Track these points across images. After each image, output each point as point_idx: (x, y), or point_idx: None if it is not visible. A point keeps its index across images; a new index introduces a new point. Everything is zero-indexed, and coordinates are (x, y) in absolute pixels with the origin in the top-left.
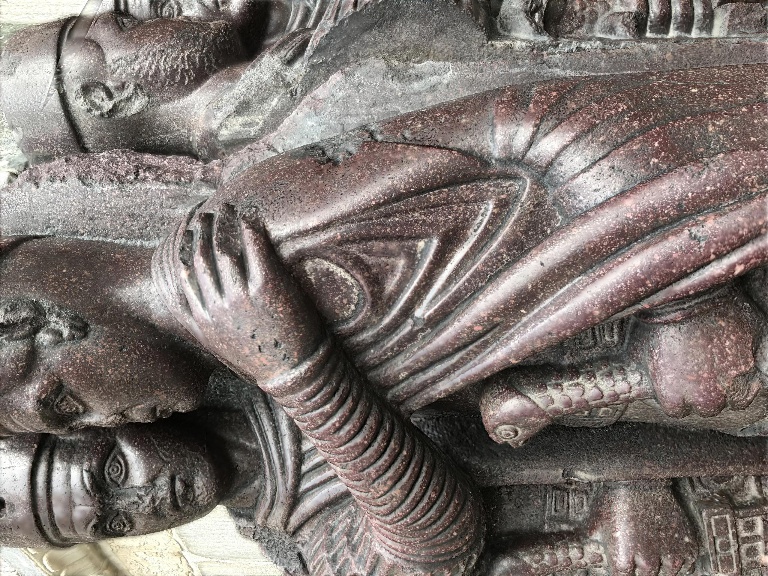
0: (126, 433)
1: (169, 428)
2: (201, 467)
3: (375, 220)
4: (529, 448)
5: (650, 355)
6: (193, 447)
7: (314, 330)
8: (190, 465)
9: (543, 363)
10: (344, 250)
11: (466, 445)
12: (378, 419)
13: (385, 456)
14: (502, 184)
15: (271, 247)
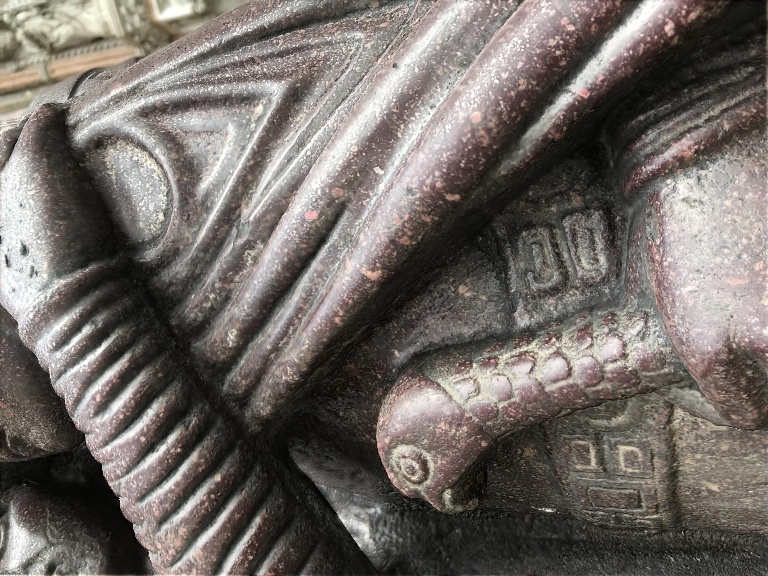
0: (22, 498)
1: (77, 502)
2: (91, 559)
3: (196, 79)
4: (541, 574)
5: (650, 257)
6: (93, 530)
7: (82, 234)
8: (78, 553)
9: (485, 336)
10: (150, 123)
11: (435, 558)
12: (174, 403)
13: (178, 475)
14: (386, 12)
15: (60, 126)
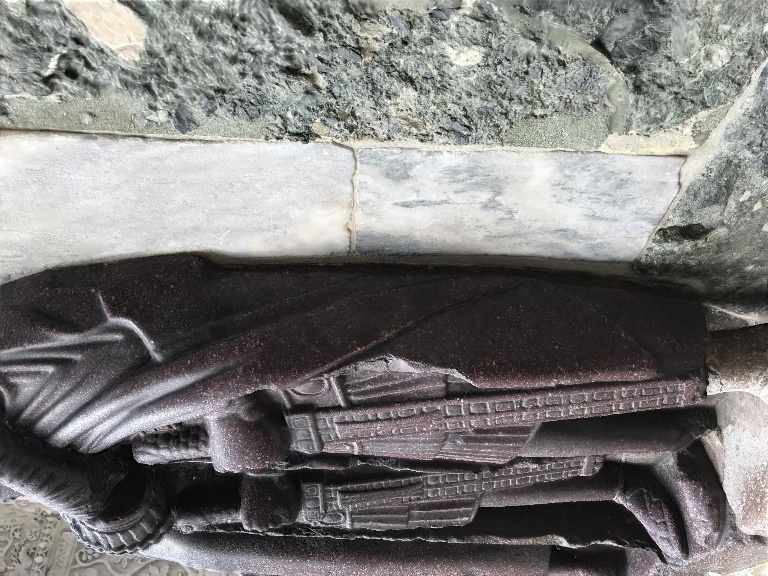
0: None
1: None
2: None
3: None
4: None
5: None
6: None
7: None
8: None
9: None
10: None
11: None
12: None
13: None
14: None
15: None
